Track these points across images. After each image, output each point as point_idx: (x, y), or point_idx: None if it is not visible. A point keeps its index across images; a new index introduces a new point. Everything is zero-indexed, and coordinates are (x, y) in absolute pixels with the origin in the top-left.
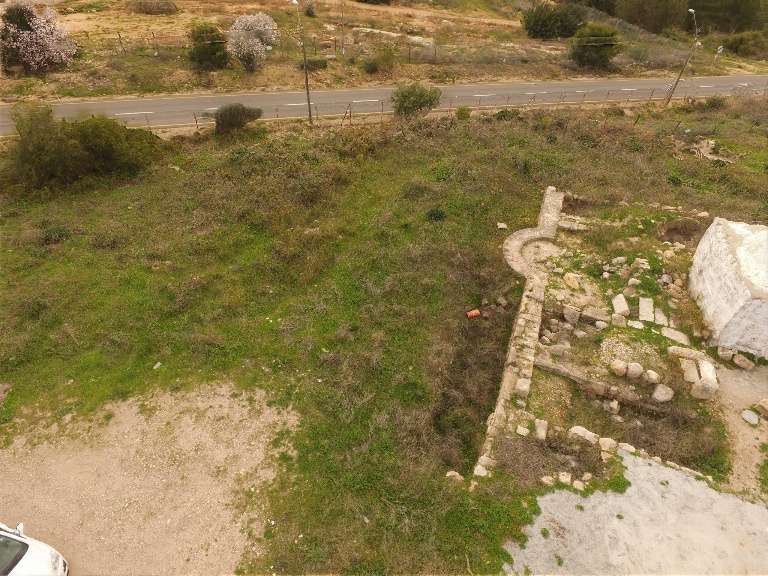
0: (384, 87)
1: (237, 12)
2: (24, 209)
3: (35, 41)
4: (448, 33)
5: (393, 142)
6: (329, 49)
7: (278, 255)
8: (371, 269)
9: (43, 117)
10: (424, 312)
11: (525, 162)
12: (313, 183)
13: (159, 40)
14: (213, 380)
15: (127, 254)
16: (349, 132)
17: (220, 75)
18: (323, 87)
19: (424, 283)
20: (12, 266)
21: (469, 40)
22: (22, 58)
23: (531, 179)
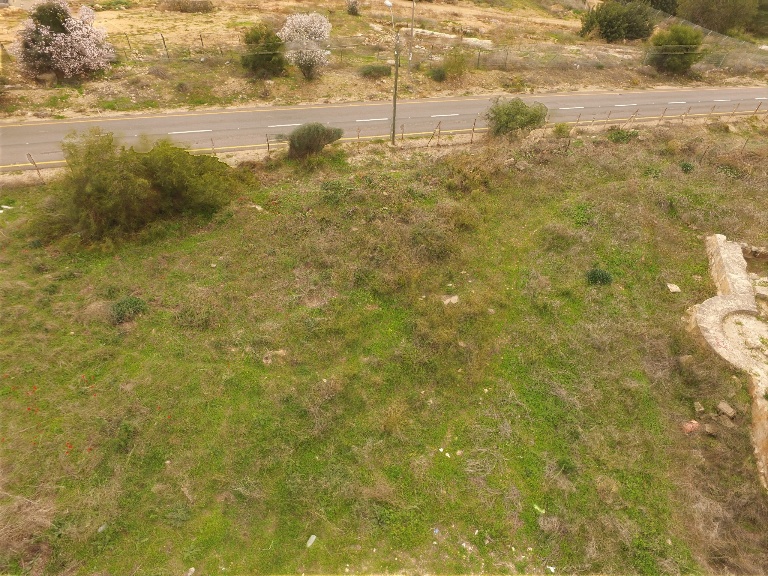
0: (459, 98)
1: (275, 10)
2: (82, 269)
3: (70, 45)
4: (514, 35)
5: (507, 173)
6: (383, 52)
7: (422, 340)
8: (549, 363)
9: (102, 149)
10: (650, 439)
11: (671, 199)
12: (439, 233)
13: (233, 49)
14: (398, 569)
15: (226, 340)
16: (456, 160)
17: (277, 84)
18: (390, 98)
19: (634, 390)
20: (79, 360)
21: (578, 48)
22: (55, 64)
23: (680, 221)
